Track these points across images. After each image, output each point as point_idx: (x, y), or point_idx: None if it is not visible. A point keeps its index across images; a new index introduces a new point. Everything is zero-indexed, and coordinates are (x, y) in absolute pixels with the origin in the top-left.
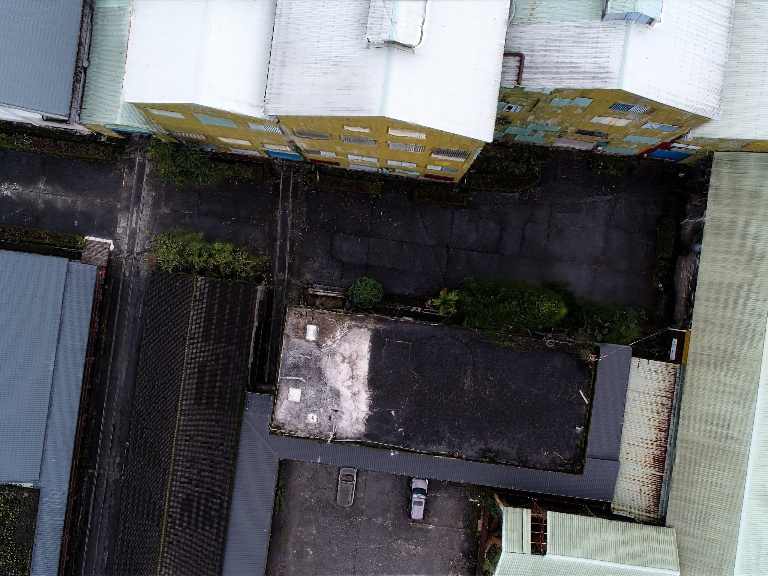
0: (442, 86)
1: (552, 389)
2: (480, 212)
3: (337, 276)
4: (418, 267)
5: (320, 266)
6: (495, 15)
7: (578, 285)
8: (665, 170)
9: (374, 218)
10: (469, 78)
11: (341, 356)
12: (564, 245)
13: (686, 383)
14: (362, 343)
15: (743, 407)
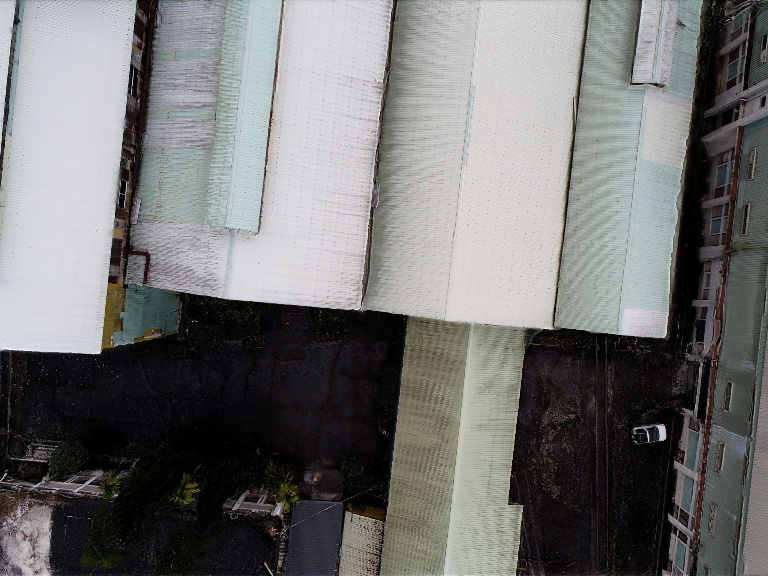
0: (32, 307)
1: (236, 562)
2: (203, 362)
3: (60, 430)
4: (141, 419)
5: (42, 420)
6: (97, 227)
7: (303, 433)
8: (390, 314)
9: (96, 370)
10: (66, 294)
11: (22, 534)
12: (288, 393)
13: (385, 546)
14: (43, 521)
15: (433, 574)
